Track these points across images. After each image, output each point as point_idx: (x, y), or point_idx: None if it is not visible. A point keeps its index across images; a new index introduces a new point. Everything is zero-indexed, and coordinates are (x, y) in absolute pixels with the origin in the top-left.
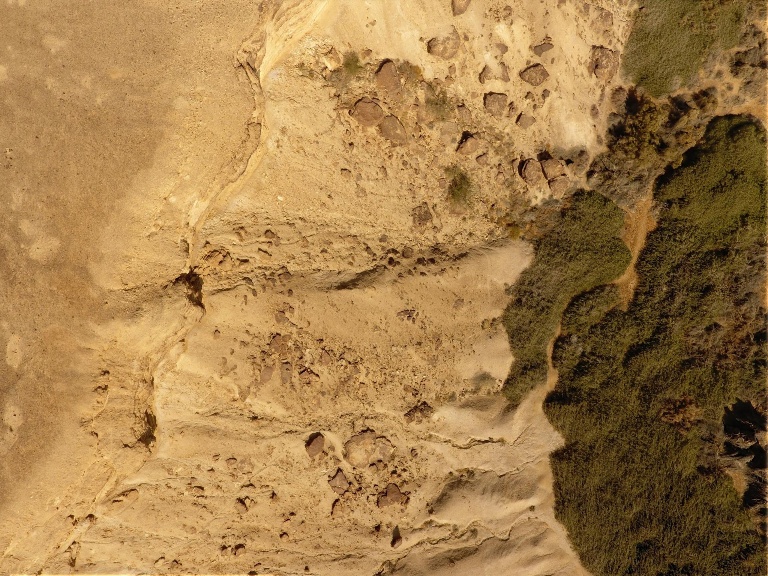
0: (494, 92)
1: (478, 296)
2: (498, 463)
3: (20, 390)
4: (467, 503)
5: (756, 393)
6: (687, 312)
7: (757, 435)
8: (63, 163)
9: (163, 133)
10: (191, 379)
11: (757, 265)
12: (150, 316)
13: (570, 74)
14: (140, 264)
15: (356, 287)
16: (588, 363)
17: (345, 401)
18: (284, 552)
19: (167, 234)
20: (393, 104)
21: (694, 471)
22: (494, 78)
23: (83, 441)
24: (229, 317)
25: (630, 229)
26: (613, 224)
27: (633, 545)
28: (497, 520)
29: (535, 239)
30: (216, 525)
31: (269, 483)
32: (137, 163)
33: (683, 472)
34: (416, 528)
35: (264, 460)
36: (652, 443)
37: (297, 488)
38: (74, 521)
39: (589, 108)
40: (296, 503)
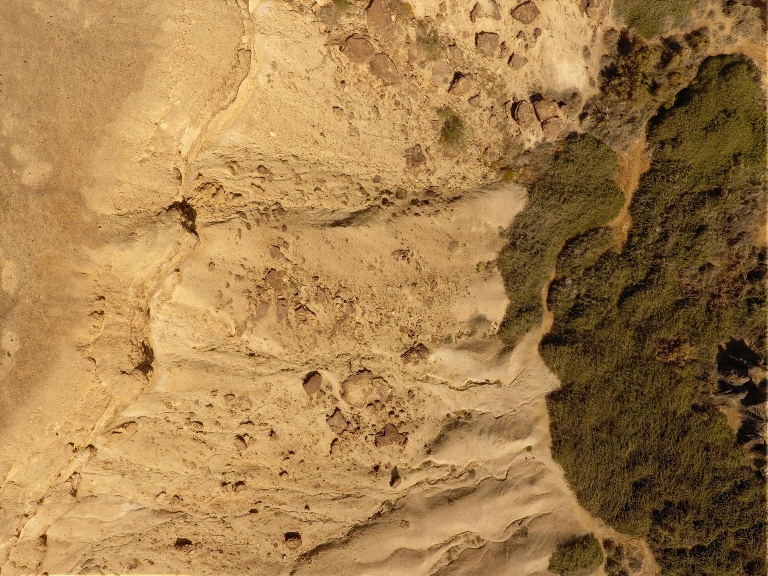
0: (485, 32)
1: (472, 239)
2: (495, 405)
3: (16, 315)
4: (465, 443)
5: (749, 331)
6: (681, 252)
7: (751, 372)
8: (52, 87)
9: (152, 55)
10: (187, 312)
11: (750, 204)
12: (144, 241)
13: (561, 13)
14: (133, 190)
15: (350, 225)
16: (583, 305)
17: (342, 341)
18: (284, 491)
19: (159, 161)
20: (384, 42)
21: (689, 409)
22: (485, 16)
23: (80, 366)
24: (224, 250)
25: (623, 171)
26: (606, 166)
27: (629, 483)
28: (495, 460)
29: (529, 183)
30: (216, 461)
31: (268, 421)
32: (127, 86)
33: (678, 410)
34: (414, 468)
35: (262, 397)
36: (647, 382)
37: (296, 427)
38: (74, 449)
39: (581, 49)
40: (295, 442)
